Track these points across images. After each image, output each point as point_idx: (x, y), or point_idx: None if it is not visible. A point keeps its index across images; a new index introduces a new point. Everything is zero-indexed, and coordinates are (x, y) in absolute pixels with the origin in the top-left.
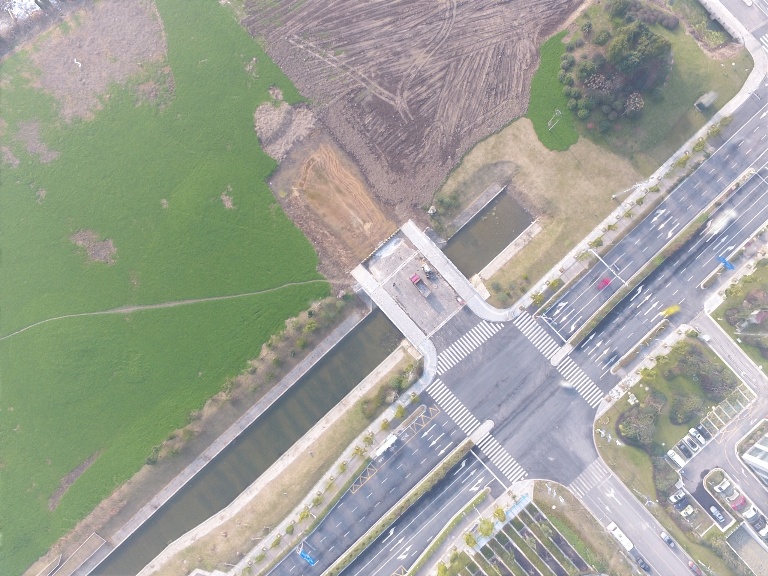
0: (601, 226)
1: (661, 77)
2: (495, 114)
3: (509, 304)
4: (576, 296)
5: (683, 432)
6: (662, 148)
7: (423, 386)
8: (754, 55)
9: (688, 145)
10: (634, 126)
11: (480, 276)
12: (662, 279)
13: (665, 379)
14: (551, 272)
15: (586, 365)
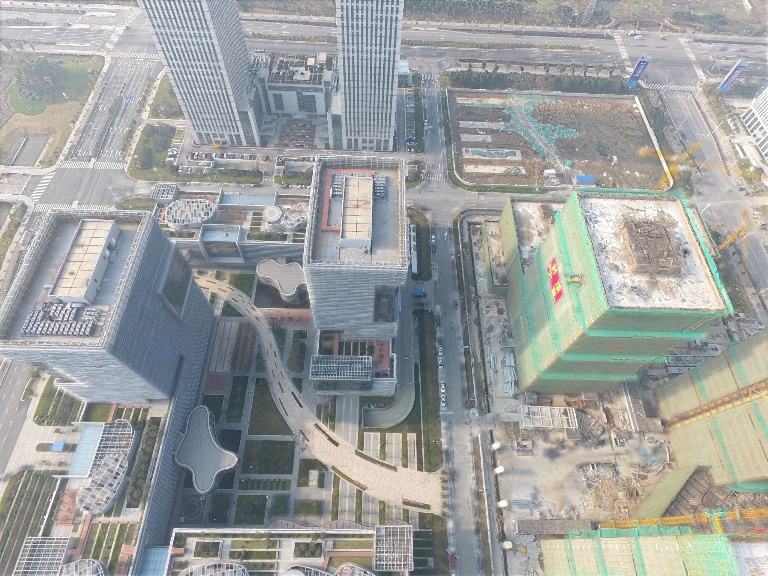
0: (78, 122)
1: (59, 72)
2: (0, 119)
3: (53, 164)
4: (84, 145)
5: (166, 152)
6: (86, 91)
7: (31, 211)
8: (102, 55)
9: (96, 85)
10: (64, 90)
11: (35, 166)
12: (118, 121)
13: (145, 144)
14: (66, 145)
15: (106, 160)
